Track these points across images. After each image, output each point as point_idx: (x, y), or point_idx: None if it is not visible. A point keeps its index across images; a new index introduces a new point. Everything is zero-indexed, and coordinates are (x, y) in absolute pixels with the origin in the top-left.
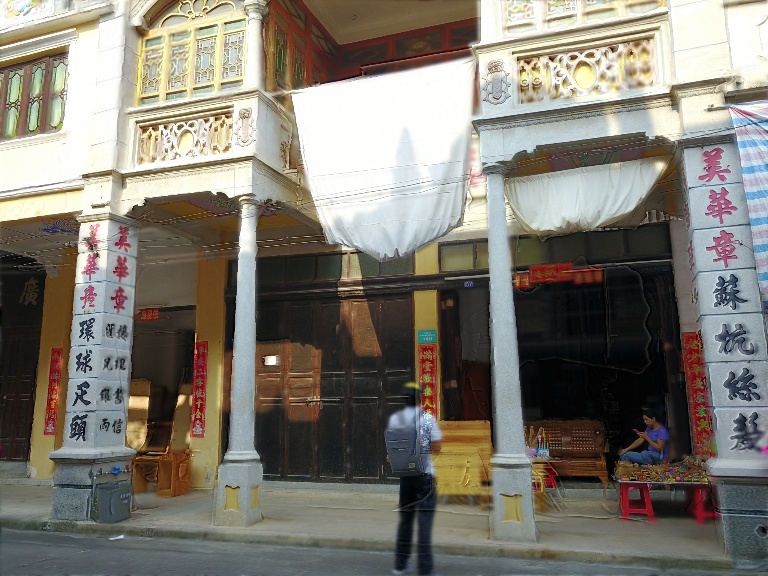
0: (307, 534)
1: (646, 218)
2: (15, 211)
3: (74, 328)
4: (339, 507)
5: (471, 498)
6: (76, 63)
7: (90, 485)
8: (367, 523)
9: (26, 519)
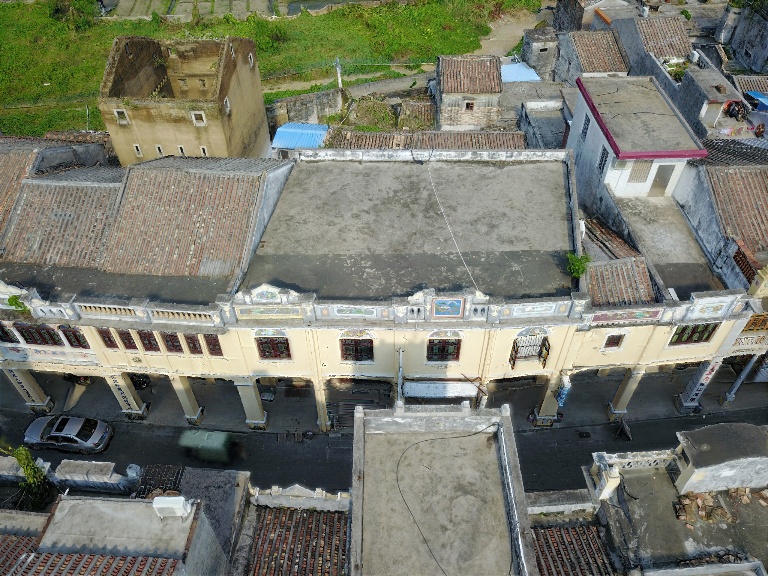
0: (748, 407)
1: (766, 140)
2: (682, 361)
3: (699, 384)
4: (726, 381)
5: (760, 375)
6: (722, 327)
7: (694, 408)
8: (748, 394)
9: (674, 416)
